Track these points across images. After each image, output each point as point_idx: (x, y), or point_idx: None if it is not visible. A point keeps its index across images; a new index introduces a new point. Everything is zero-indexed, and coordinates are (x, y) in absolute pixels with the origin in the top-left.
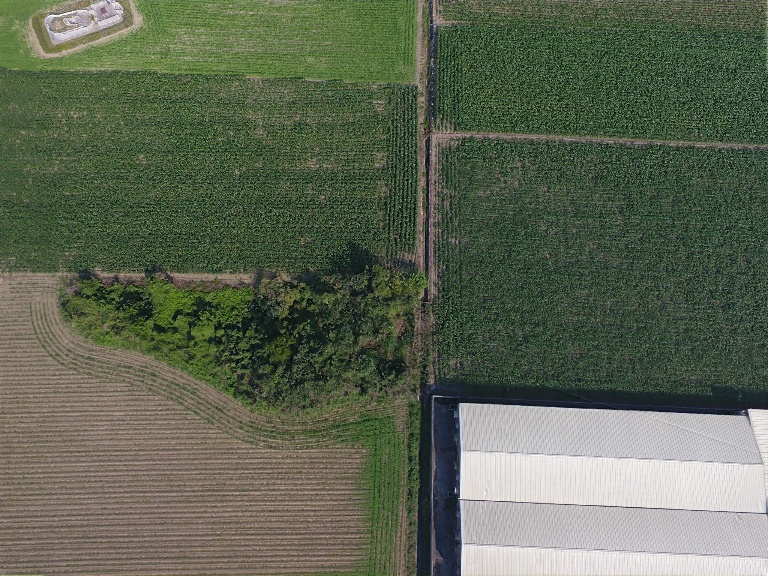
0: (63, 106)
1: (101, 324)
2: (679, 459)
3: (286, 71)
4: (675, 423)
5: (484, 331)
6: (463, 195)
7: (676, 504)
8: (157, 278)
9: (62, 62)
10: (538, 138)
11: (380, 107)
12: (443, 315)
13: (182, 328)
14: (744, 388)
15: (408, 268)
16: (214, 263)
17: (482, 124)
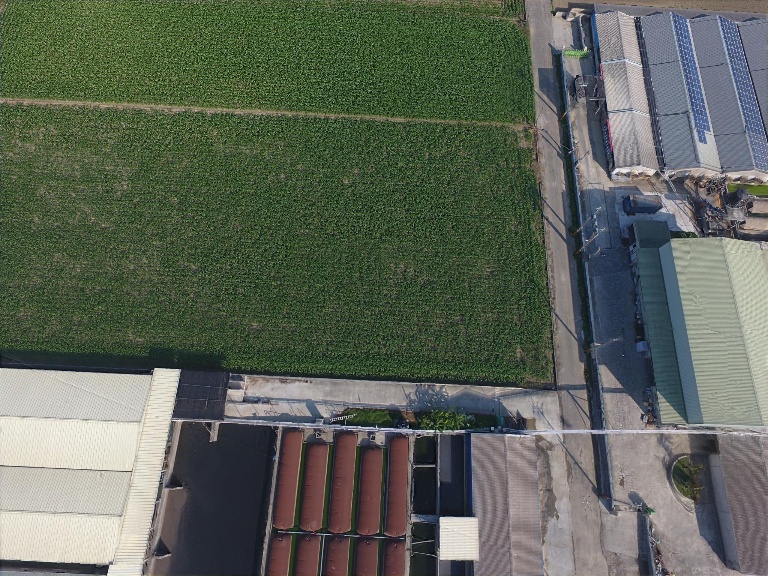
0: None
1: None
2: (54, 417)
3: None
4: (72, 382)
5: None
6: None
7: (39, 462)
8: None
9: None
10: (74, 104)
11: None
12: None
13: None
14: (184, 349)
15: None
16: None
17: (16, 90)
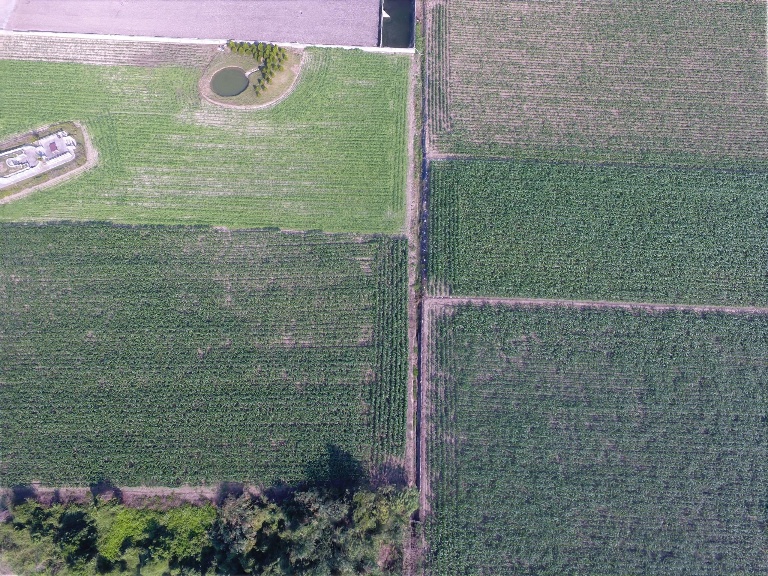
0: (3, 269)
1: (36, 560)
2: None
3: (259, 220)
4: None
5: (484, 562)
6: (460, 380)
7: None
8: (102, 501)
9: (4, 211)
10: (545, 303)
11: (365, 265)
12: (437, 541)
13: (131, 561)
14: None
15: (396, 475)
16: (170, 475)
17: (481, 287)
